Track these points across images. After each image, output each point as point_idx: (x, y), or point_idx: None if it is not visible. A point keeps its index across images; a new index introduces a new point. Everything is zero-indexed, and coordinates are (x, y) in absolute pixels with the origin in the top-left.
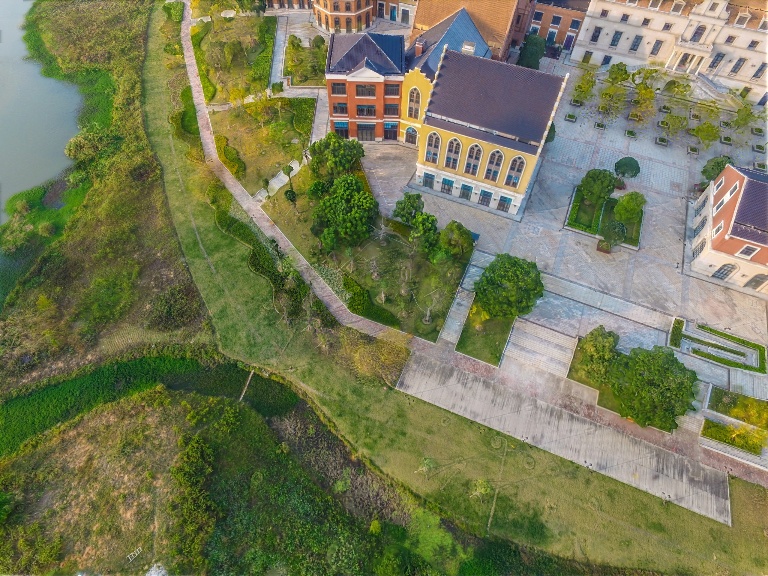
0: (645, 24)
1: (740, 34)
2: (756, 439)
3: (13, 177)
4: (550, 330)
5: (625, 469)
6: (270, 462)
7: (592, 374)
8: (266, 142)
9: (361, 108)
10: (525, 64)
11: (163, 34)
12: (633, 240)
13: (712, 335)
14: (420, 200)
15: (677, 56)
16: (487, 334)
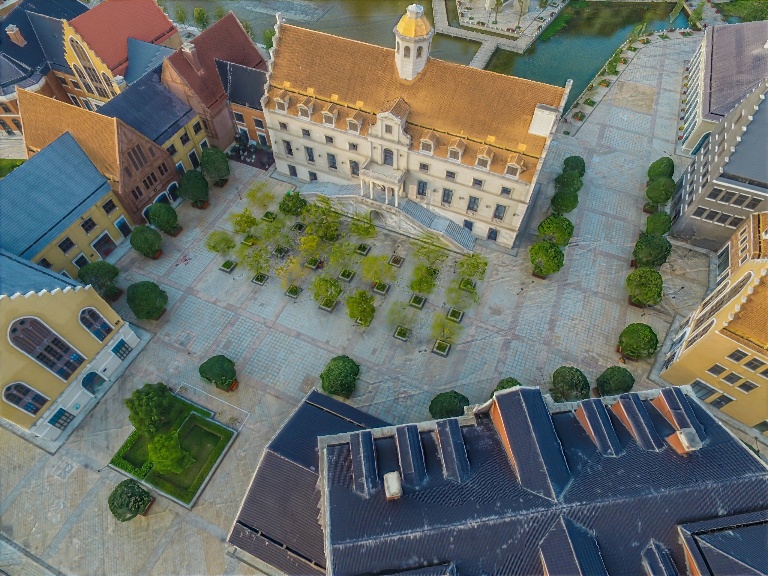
0: (330, 141)
1: (431, 162)
2: None
3: None
4: None
5: None
6: None
7: None
8: None
9: None
10: (182, 192)
11: None
12: (185, 493)
13: None
14: None
15: (367, 184)
16: None
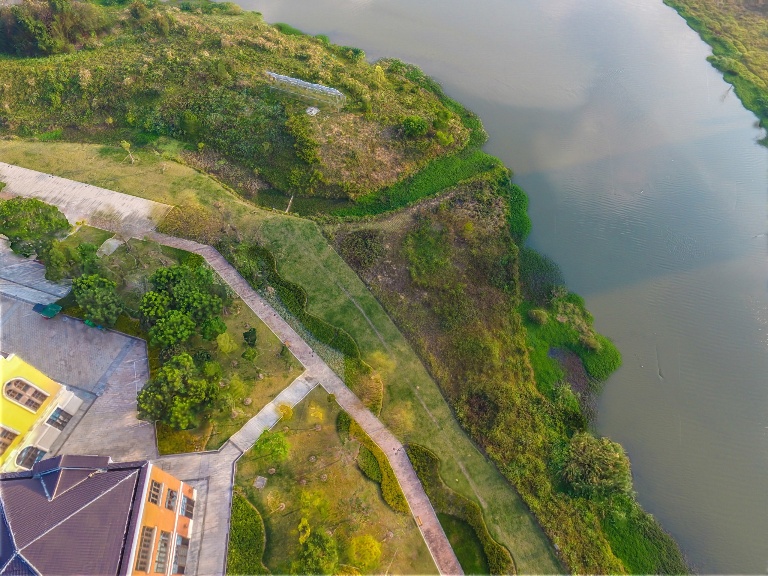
0: None
1: None
2: None
3: (649, 392)
4: None
5: (27, 176)
6: (264, 163)
7: None
8: None
9: None
10: None
11: None
12: None
13: None
14: None
15: None
16: (80, 241)
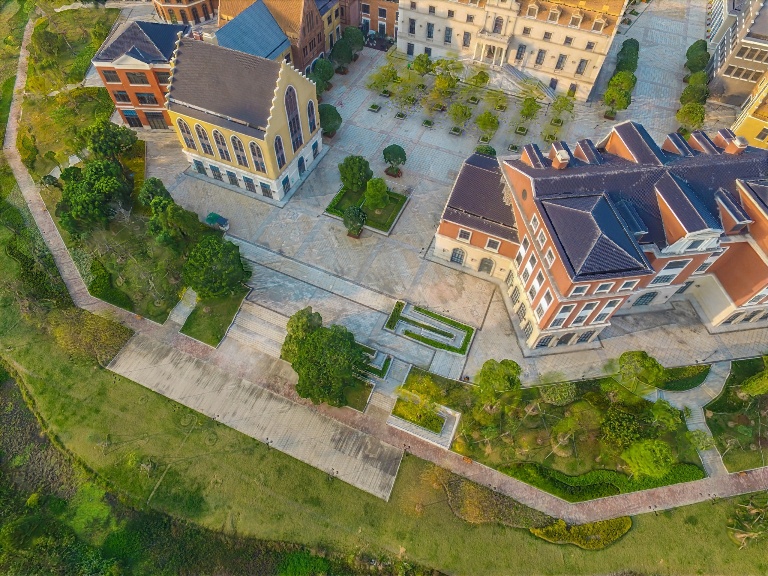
0: (451, 16)
1: (533, 25)
2: (441, 418)
3: None
4: (273, 312)
5: (304, 446)
6: None
7: (289, 354)
8: (41, 129)
9: (141, 96)
10: (335, 55)
11: (8, 26)
12: (384, 226)
13: (427, 317)
14: (159, 184)
15: (480, 47)
16: (213, 316)
